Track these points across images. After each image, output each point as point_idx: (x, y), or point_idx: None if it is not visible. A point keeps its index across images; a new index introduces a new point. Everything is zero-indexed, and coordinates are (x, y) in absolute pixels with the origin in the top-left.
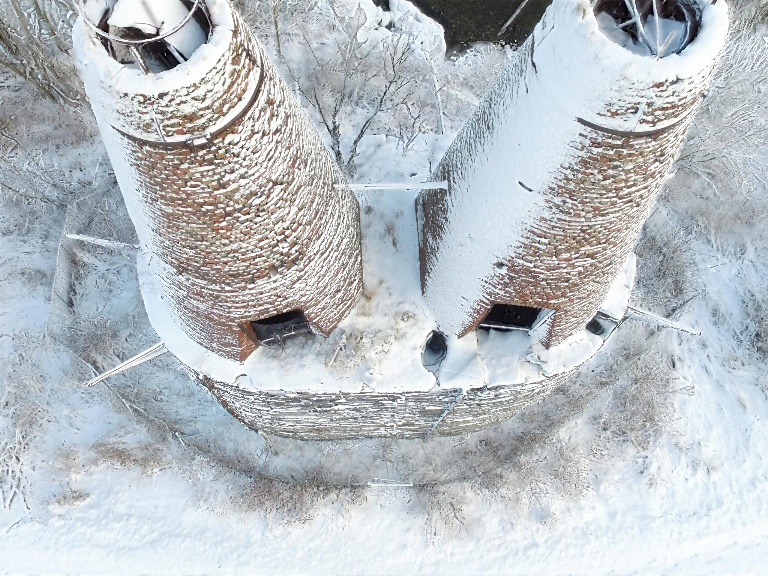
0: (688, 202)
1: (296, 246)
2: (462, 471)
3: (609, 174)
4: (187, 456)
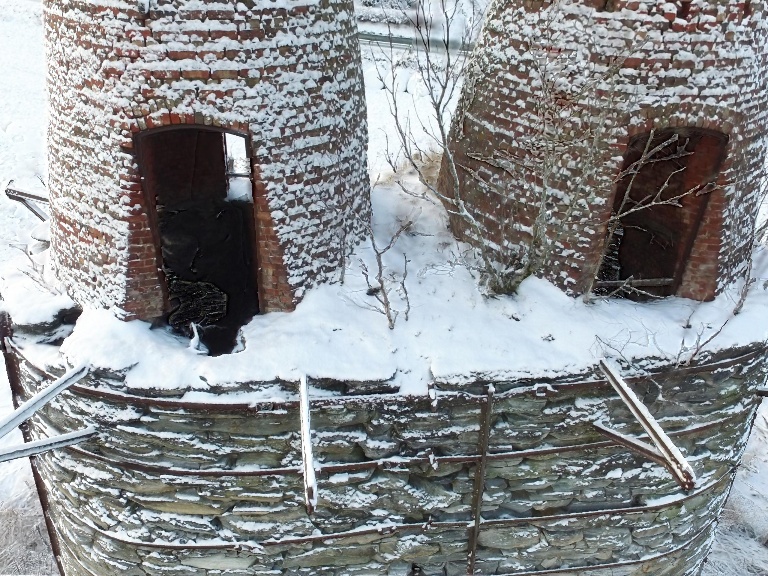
0: None
1: None
2: None
3: None
4: None
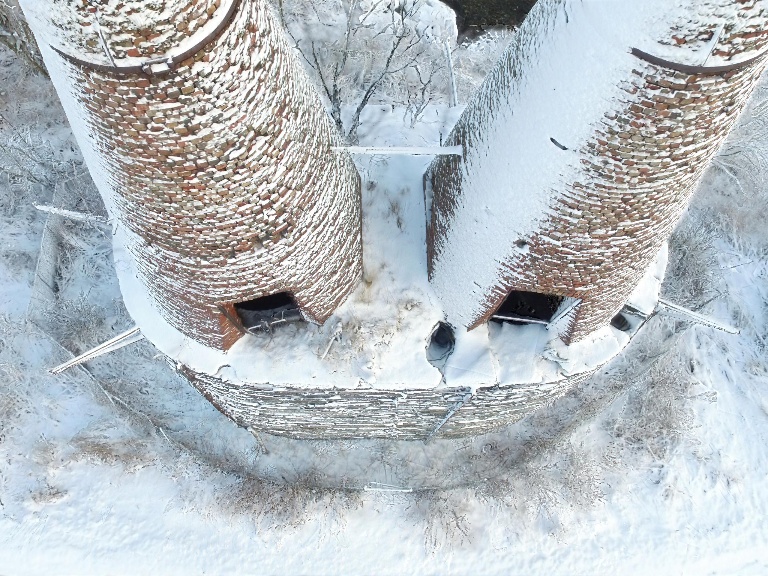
0: (709, 199)
1: (284, 214)
2: (465, 476)
3: (665, 125)
4: (172, 453)
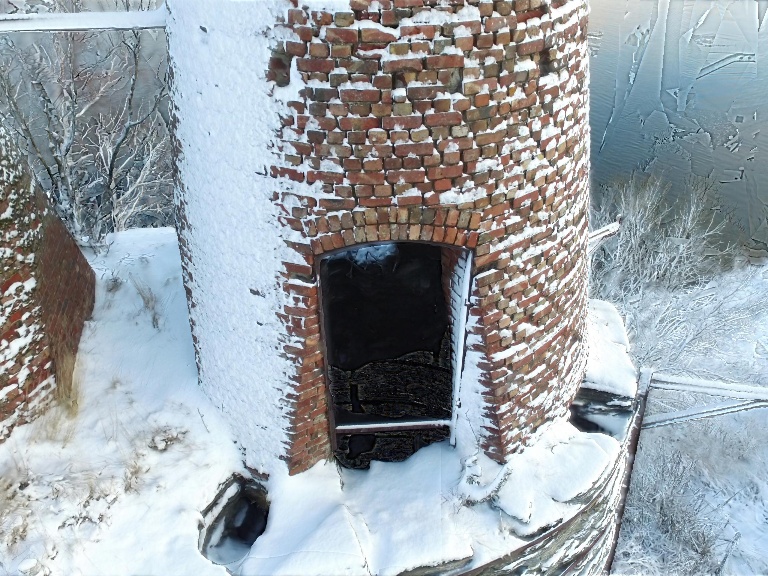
0: None
1: None
2: None
3: None
4: None
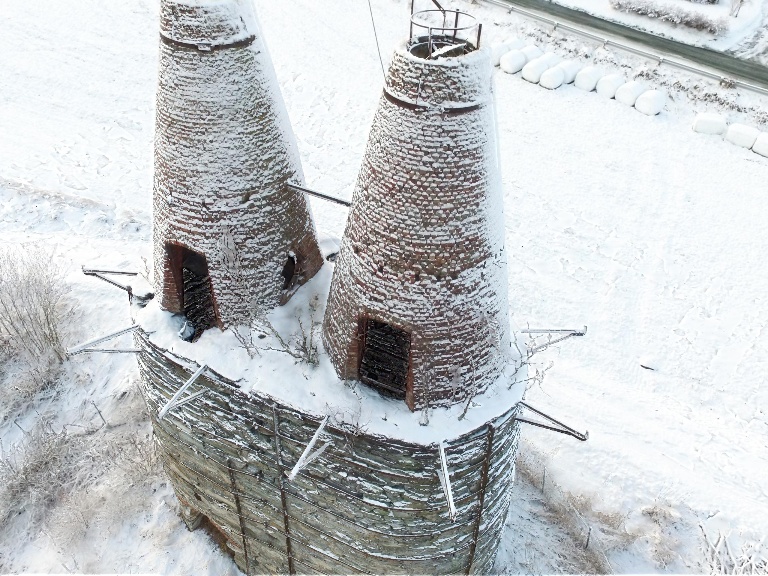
0: None
1: None
2: None
3: None
4: None
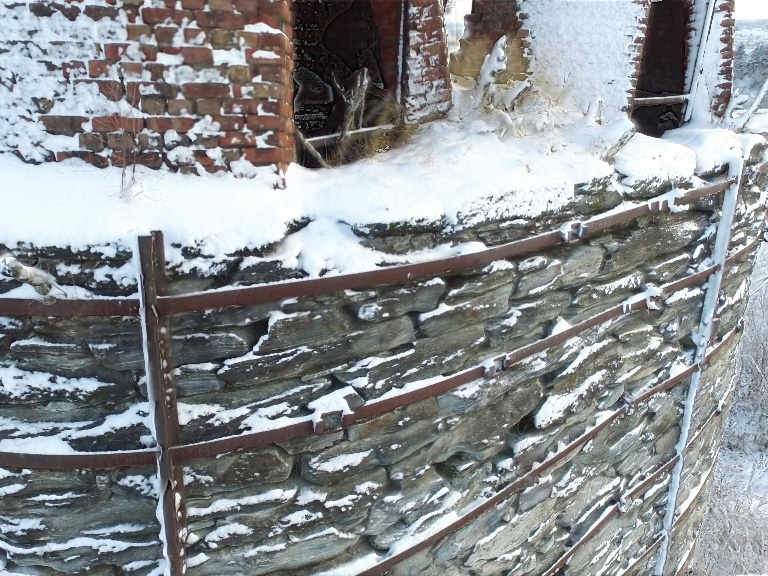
0: None
1: None
2: None
3: None
4: None
